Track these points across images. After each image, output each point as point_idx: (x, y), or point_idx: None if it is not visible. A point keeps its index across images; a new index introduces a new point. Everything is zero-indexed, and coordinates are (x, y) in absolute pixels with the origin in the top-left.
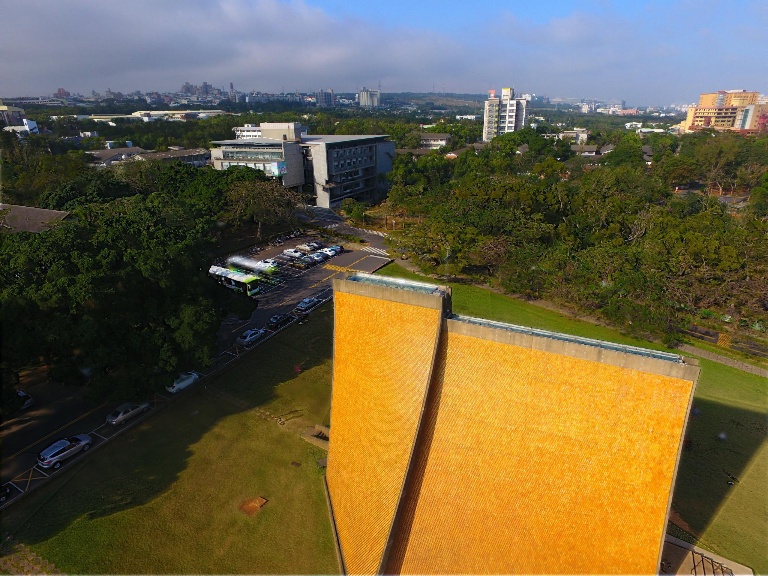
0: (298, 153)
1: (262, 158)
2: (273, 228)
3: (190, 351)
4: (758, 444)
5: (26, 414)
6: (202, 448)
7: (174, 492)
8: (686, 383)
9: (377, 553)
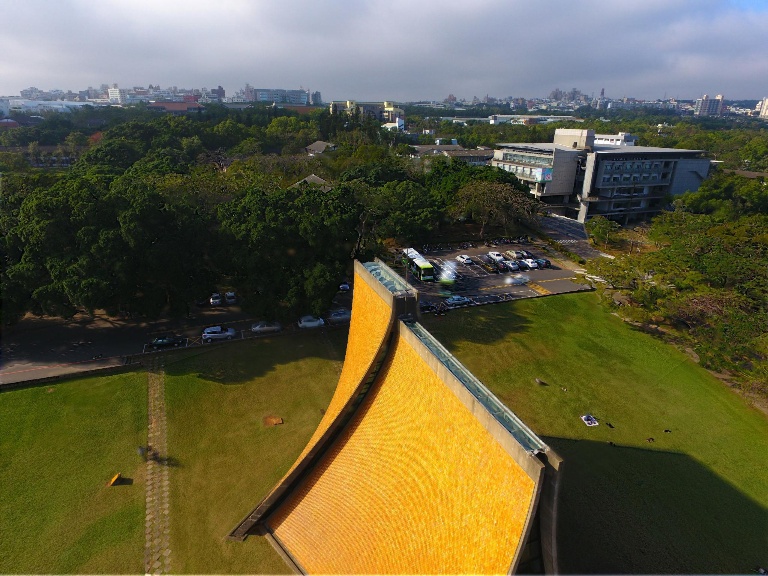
0: (572, 161)
1: (534, 163)
2: (504, 231)
3: (310, 298)
4: None
5: (228, 307)
6: (282, 370)
7: (244, 387)
8: (529, 481)
9: (275, 488)
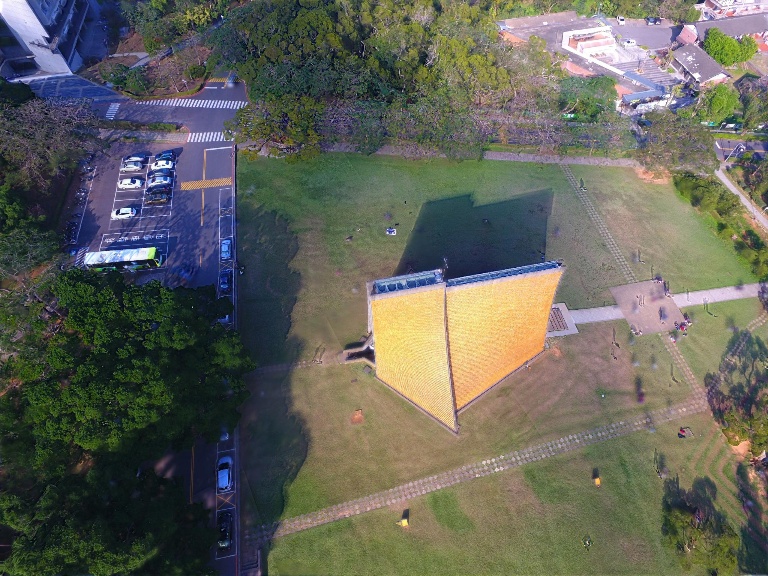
0: None
1: None
2: None
3: (239, 367)
4: (544, 222)
5: None
6: (295, 410)
7: (312, 442)
8: None
9: (448, 401)
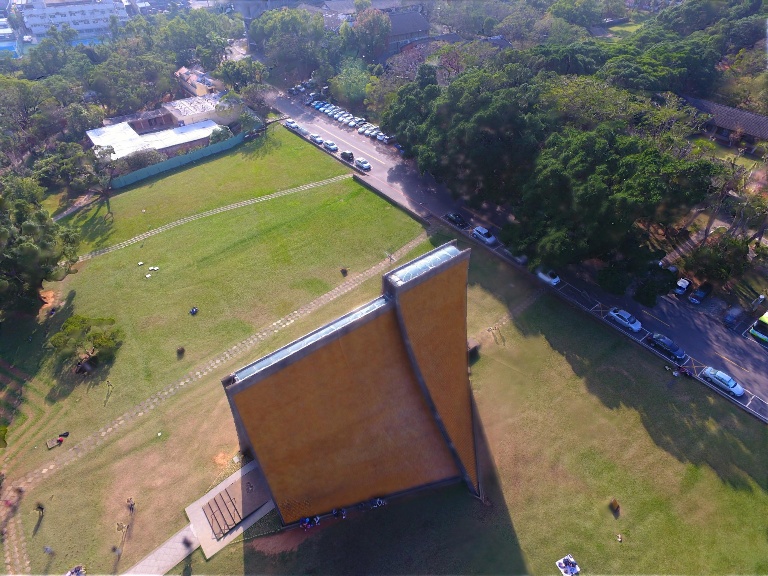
0: None
1: None
2: None
3: None
4: None
5: None
6: (476, 289)
7: None
8: None
9: None
